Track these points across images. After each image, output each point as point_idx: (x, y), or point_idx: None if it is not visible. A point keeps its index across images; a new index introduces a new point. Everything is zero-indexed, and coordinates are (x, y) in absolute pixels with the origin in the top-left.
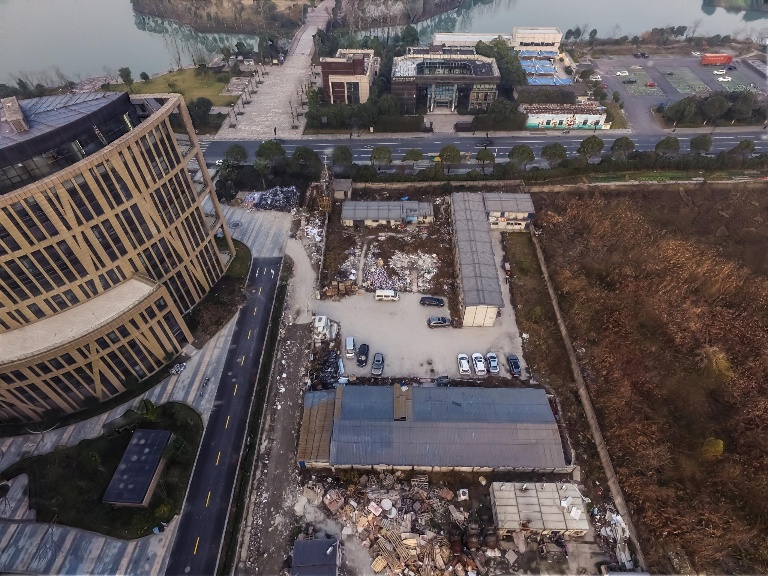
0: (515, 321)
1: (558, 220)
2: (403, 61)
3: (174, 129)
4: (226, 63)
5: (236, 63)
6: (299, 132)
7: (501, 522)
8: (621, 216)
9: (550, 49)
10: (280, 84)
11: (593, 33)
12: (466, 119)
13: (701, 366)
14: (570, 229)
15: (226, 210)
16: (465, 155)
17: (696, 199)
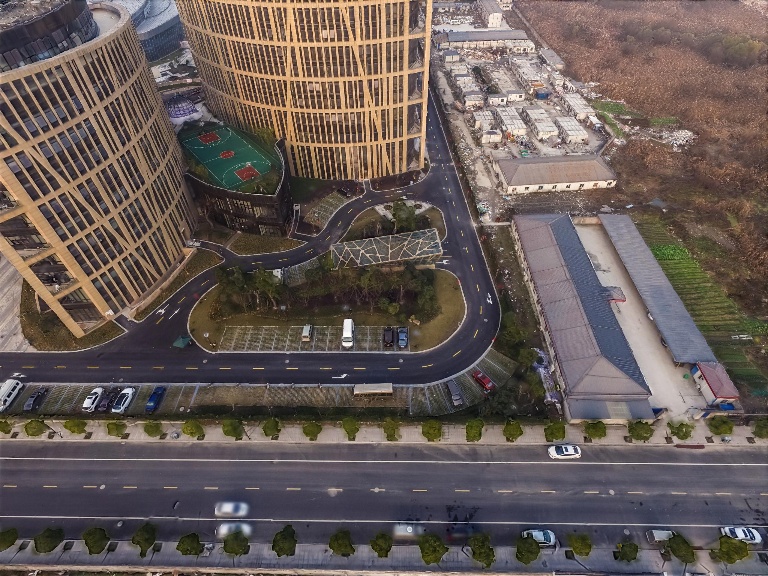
0: (509, 26)
1: (526, 5)
2: None
3: None
4: None
5: None
6: None
7: (507, 46)
8: (553, 1)
9: None
10: None
11: None
12: None
13: (579, 28)
14: (531, 8)
15: None
16: None
17: (590, 1)
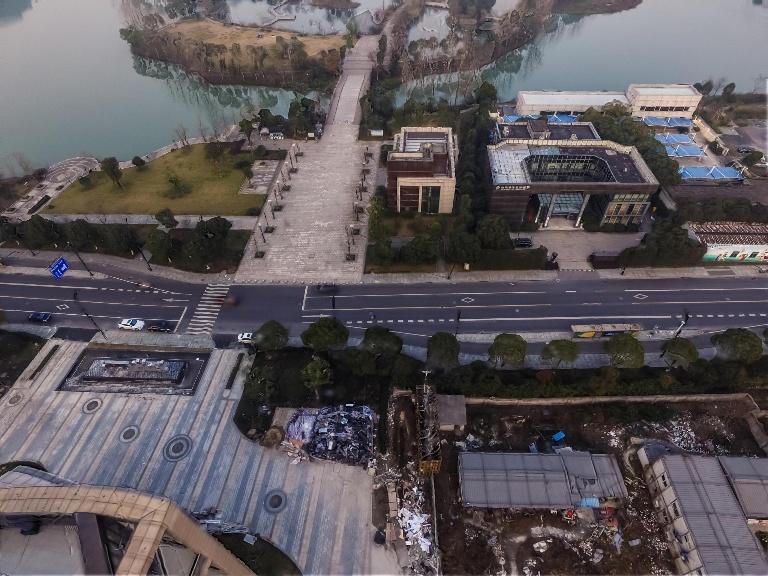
0: None
1: None
2: (500, 150)
3: (175, 262)
4: (246, 136)
5: (261, 145)
6: (358, 268)
7: None
8: None
9: (681, 115)
10: (321, 173)
11: (729, 88)
12: (600, 241)
13: None
14: None
15: (258, 458)
16: (632, 330)
17: None
